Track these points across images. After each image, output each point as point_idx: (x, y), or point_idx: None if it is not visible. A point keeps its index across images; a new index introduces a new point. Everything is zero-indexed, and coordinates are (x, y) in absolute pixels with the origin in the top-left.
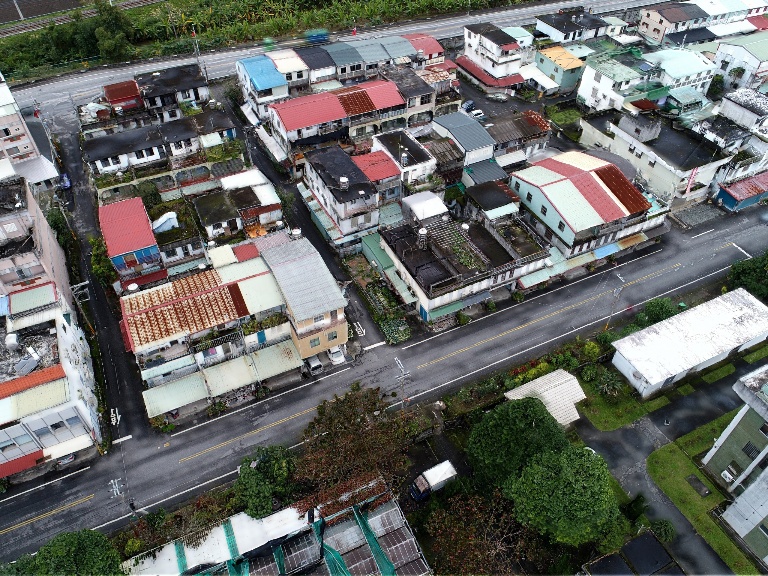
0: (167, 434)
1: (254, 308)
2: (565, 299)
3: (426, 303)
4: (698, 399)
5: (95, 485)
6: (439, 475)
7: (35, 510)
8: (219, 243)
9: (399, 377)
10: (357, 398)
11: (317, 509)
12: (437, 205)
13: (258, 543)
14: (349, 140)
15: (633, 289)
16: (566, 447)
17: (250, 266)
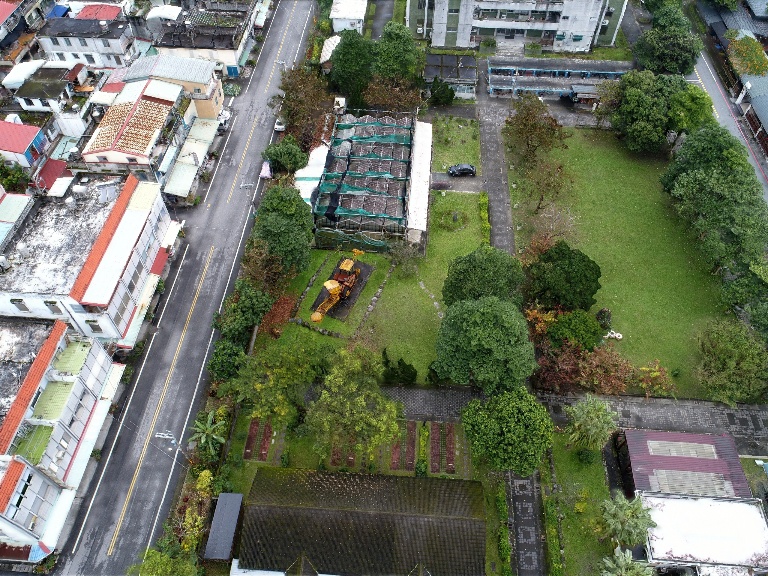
0: (201, 204)
1: (172, 98)
2: (280, 26)
3: (233, 59)
4: (378, 22)
5: (206, 244)
6: (341, 103)
7: (196, 275)
8: (72, 110)
9: (285, 69)
10: (291, 73)
11: (323, 139)
12: (172, 9)
13: (320, 169)
14: (29, 30)
15: (300, 4)
16: None
17: (131, 88)
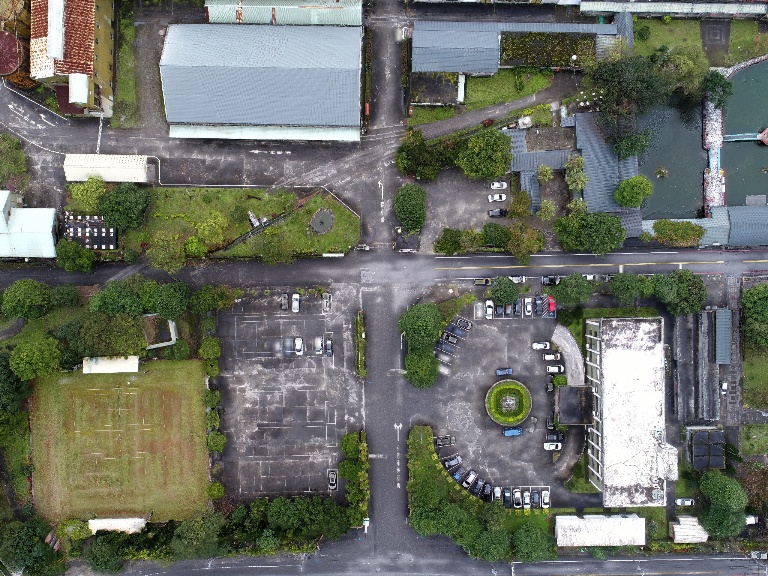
0: None
1: None
2: None
3: None
4: None
5: None
6: (749, 520)
7: None
8: None
9: (766, 566)
10: None
11: None
12: None
13: None
14: None
15: (593, 571)
16: (716, 509)
17: None
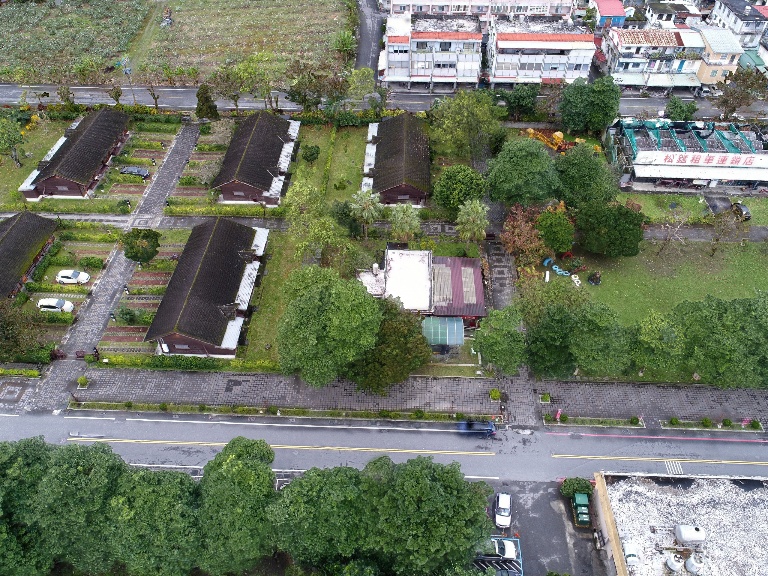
0: None
1: (687, 44)
2: None
3: None
4: None
5: None
6: None
7: None
8: None
9: None
10: (751, 74)
11: None
12: None
13: None
14: None
15: None
16: None
17: (685, 30)
